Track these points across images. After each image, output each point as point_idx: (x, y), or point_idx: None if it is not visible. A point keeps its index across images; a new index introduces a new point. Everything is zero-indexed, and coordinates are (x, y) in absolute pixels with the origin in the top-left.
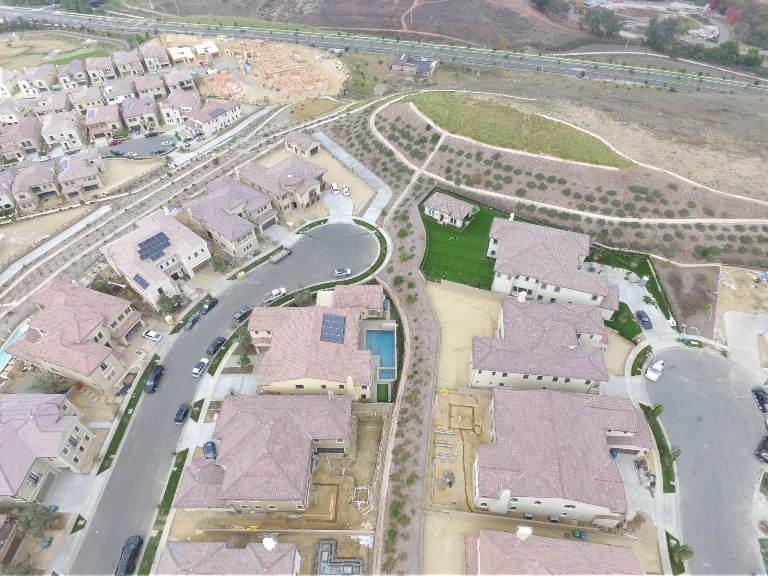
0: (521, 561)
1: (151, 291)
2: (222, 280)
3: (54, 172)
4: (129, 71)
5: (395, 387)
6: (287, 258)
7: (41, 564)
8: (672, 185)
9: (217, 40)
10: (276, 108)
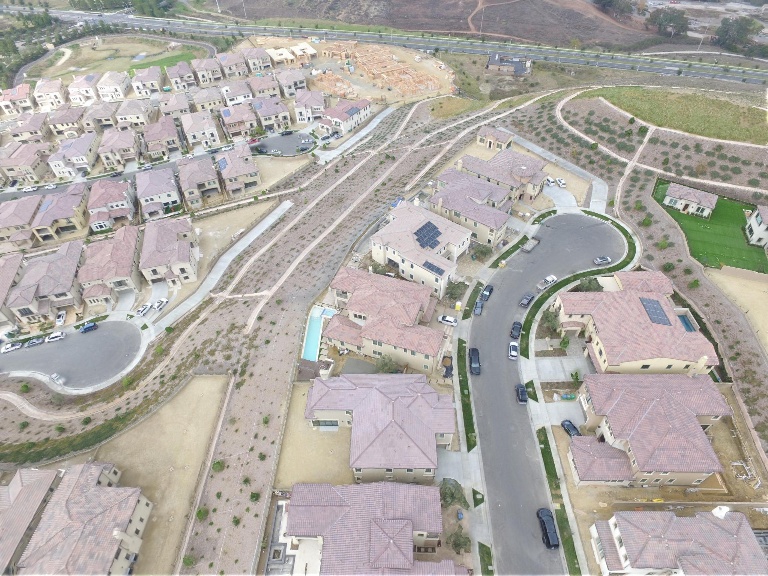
0: None
1: (445, 277)
2: (485, 268)
3: None
4: (234, 72)
5: (723, 368)
6: (537, 247)
7: (464, 535)
8: None
9: (308, 42)
10: (403, 107)
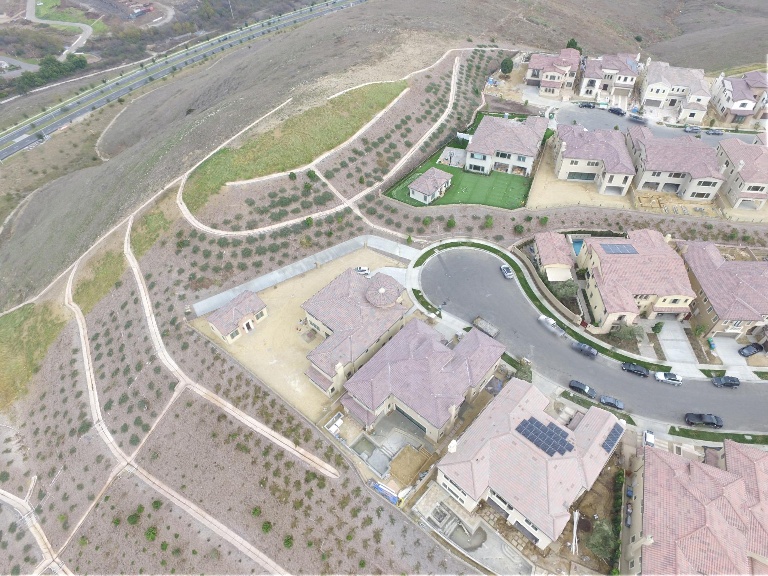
0: (757, 167)
1: None
2: (534, 384)
3: None
4: None
5: None
6: None
7: None
8: (427, 76)
9: None
10: None
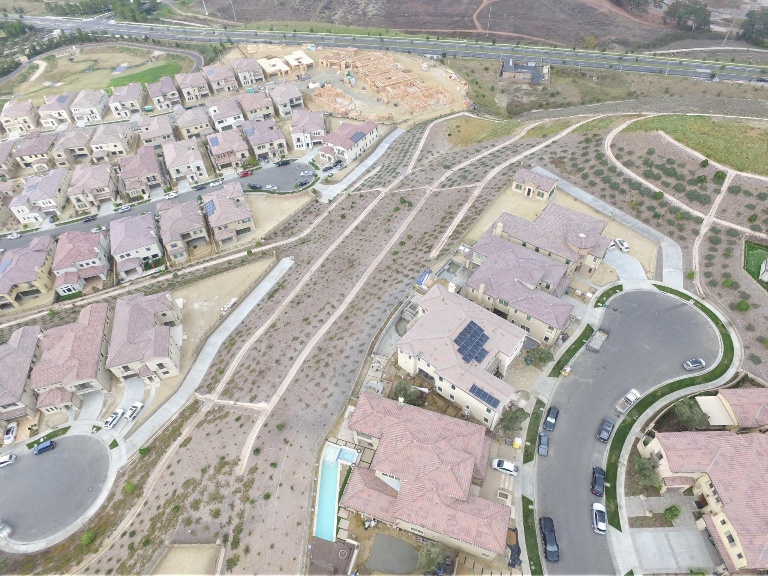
0: None
1: None
2: (543, 377)
3: (201, 214)
4: (223, 87)
5: None
6: (606, 343)
7: None
8: None
9: (303, 49)
10: (414, 128)
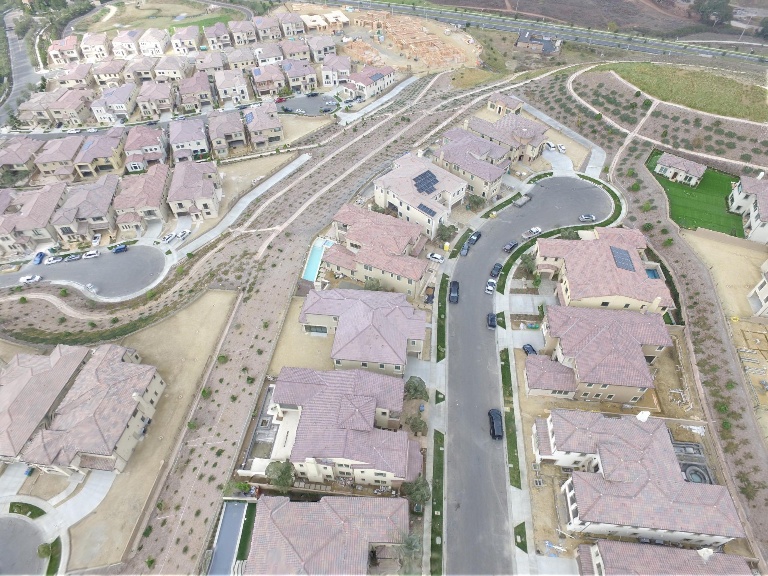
0: None
1: (437, 219)
2: (476, 218)
3: (242, 122)
4: (268, 35)
5: (679, 314)
6: (529, 203)
7: None
8: None
9: (342, 10)
10: (426, 76)
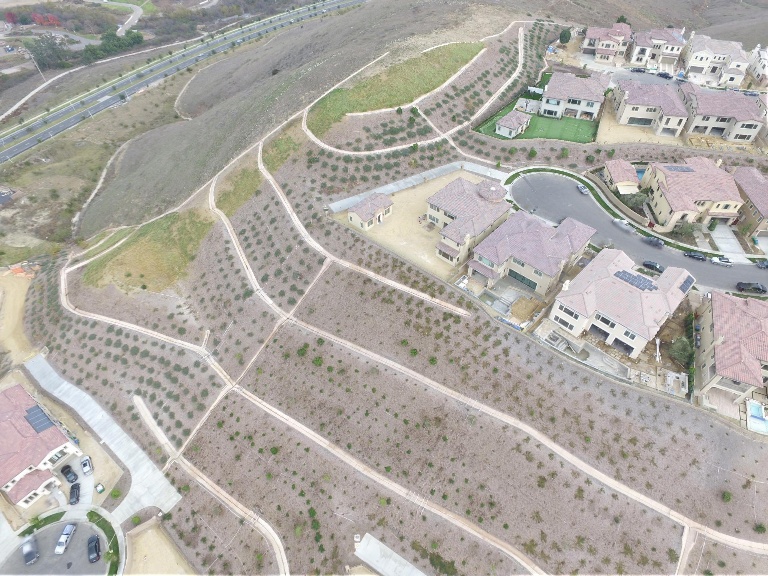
0: None
1: None
2: None
3: None
4: None
5: None
6: None
7: None
8: (499, 41)
9: None
10: (53, 339)
